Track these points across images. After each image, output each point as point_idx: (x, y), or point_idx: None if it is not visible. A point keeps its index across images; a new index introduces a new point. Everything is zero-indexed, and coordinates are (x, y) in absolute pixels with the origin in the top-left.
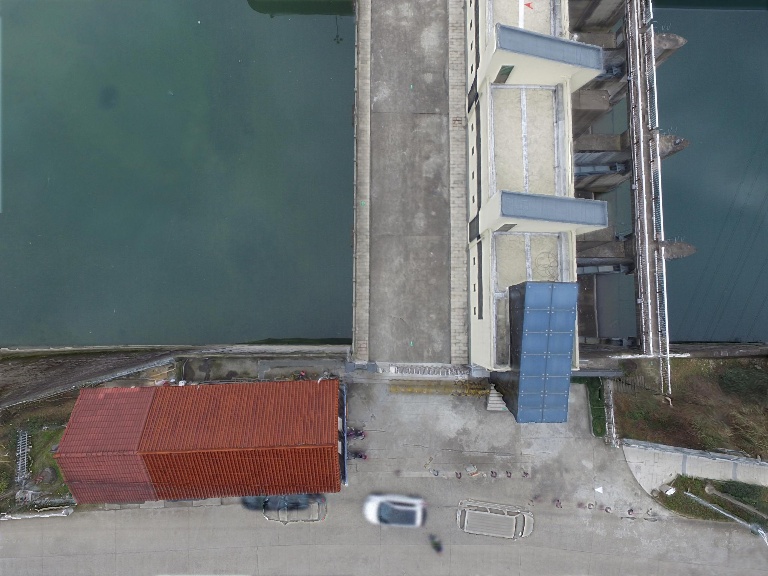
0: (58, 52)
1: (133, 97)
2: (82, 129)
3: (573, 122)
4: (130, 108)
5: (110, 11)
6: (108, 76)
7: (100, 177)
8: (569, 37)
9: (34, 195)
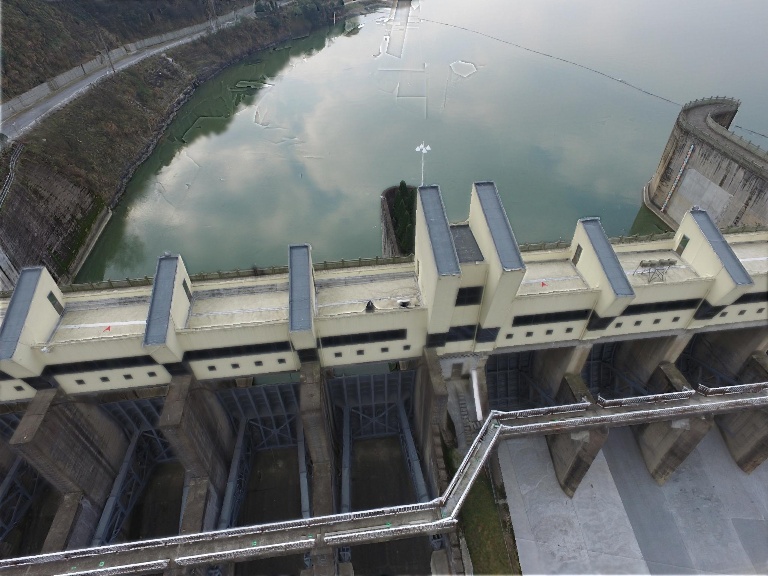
0: (292, 221)
1: (257, 250)
2: (239, 234)
3: None
4: (250, 250)
5: (319, 235)
6: (275, 240)
7: (205, 244)
8: (45, 343)
9: (200, 222)
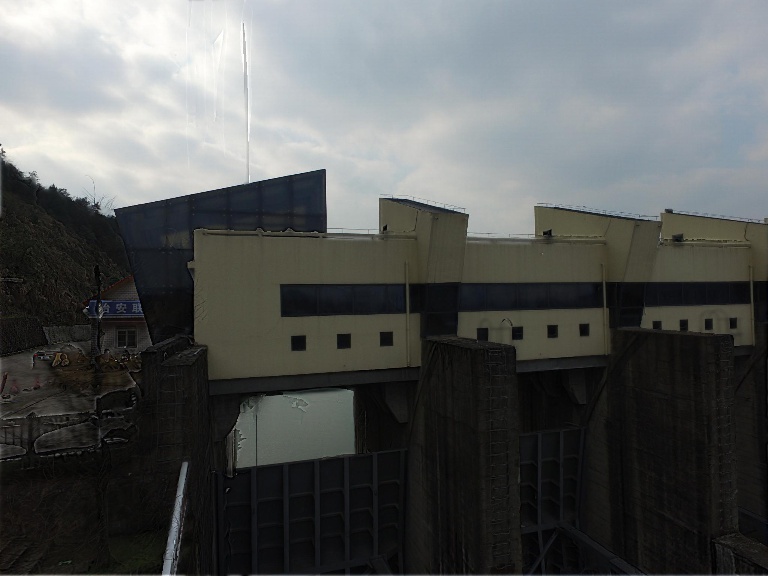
0: None
1: None
2: None
3: (668, 386)
4: None
5: None
6: None
7: None
8: None
9: (349, 423)
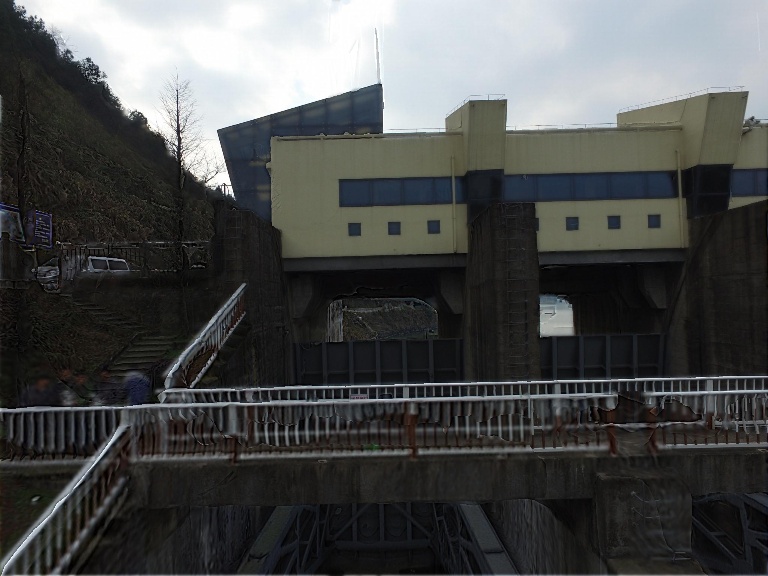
0: None
1: None
2: None
3: (744, 264)
4: None
5: None
6: None
7: None
8: None
9: None
